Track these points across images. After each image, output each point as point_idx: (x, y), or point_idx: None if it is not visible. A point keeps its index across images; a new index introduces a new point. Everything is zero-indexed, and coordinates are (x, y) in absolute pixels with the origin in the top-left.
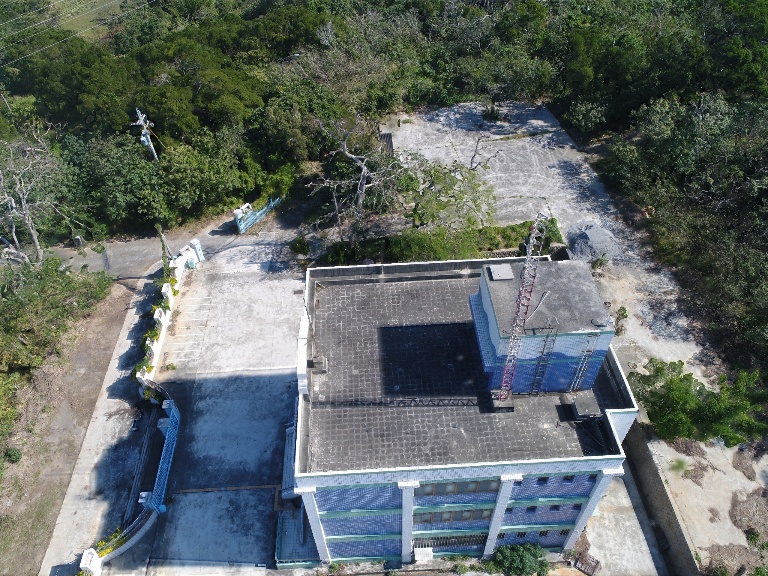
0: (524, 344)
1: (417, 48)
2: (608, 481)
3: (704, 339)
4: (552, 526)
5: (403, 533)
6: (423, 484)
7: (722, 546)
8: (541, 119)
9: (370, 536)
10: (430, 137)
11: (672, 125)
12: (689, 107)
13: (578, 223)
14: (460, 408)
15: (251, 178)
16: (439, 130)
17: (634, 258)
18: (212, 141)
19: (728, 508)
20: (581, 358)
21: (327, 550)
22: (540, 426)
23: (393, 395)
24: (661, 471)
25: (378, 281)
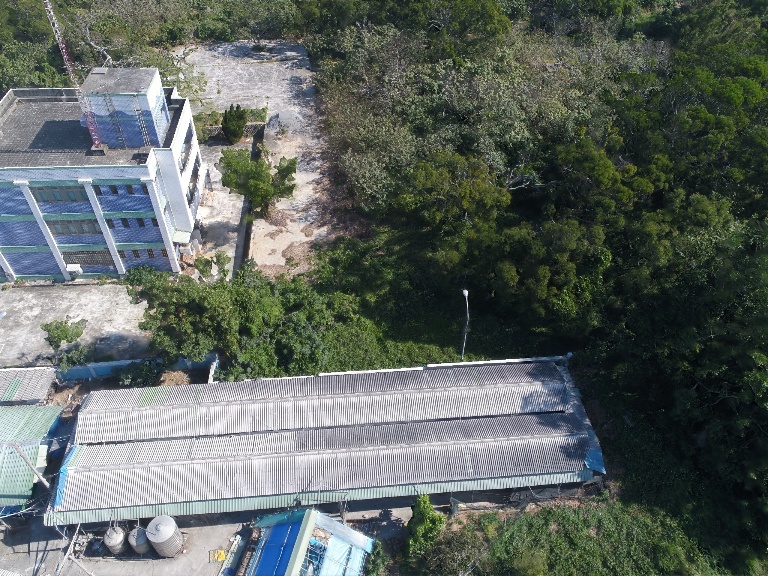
0: (94, 102)
1: (224, 3)
2: (153, 192)
3: (326, 172)
4: (149, 244)
5: (48, 243)
6: (36, 189)
7: (268, 265)
8: (295, 51)
9: (29, 247)
10: (204, 60)
11: (352, 42)
12: (375, 34)
13: (282, 111)
14: (74, 154)
15: (49, 78)
16: (214, 56)
17: (308, 130)
18: (16, 47)
19: (284, 249)
20: (137, 116)
21: (6, 262)
22: (117, 161)
23: (35, 148)
24: (253, 233)
25: (61, 101)
